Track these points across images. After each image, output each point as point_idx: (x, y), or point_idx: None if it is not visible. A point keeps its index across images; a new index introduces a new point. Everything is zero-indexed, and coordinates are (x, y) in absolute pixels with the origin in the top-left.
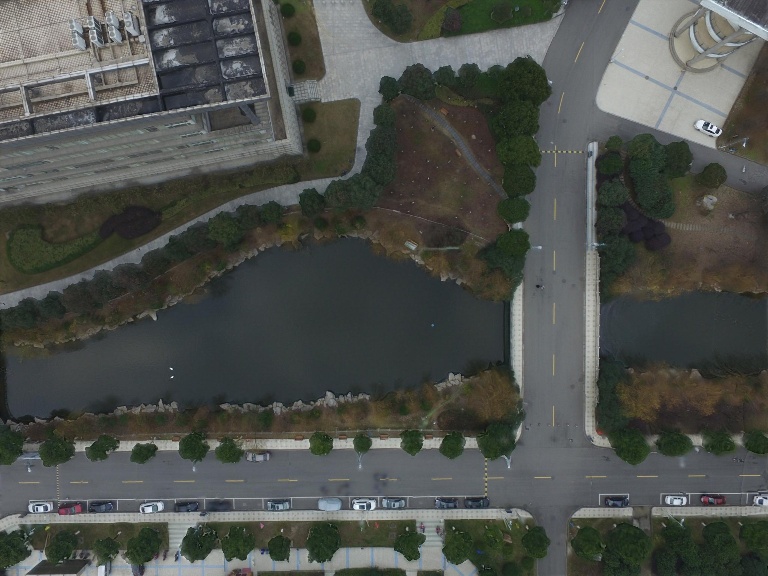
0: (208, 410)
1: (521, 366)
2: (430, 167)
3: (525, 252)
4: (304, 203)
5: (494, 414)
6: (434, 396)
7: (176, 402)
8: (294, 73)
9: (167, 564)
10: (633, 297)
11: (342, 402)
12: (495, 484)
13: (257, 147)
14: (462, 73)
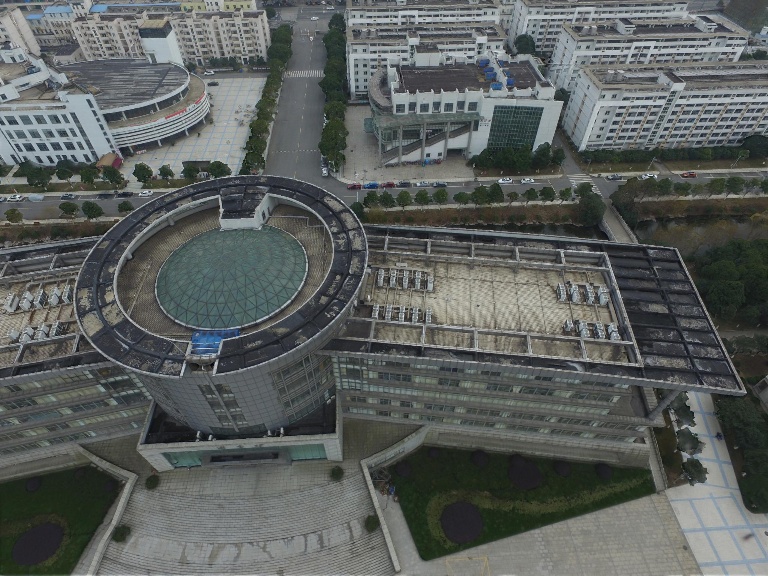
0: None
1: None
2: None
3: None
4: None
5: None
6: None
7: None
8: None
9: None
10: None
11: (2, 244)
12: None
13: None
14: None
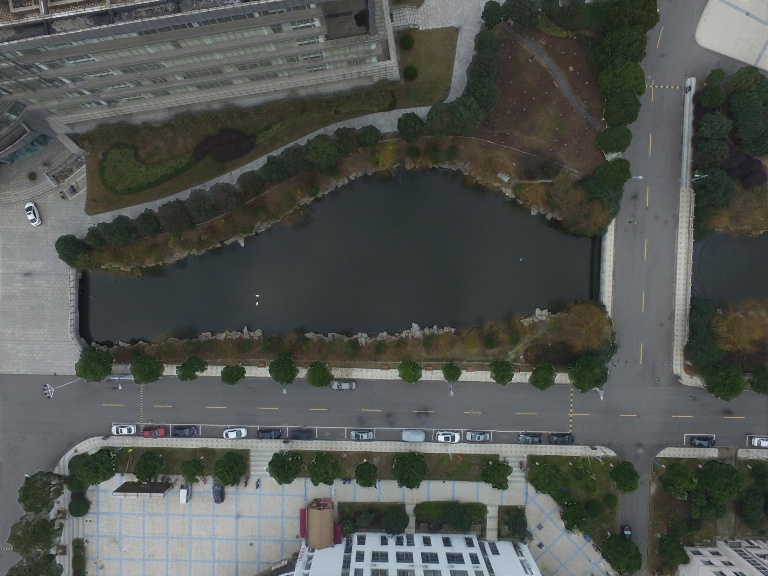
0: (296, 336)
1: (610, 302)
2: (526, 98)
3: (623, 183)
4: (406, 125)
5: (590, 344)
6: (522, 330)
7: (261, 330)
8: None
9: (247, 491)
10: (724, 237)
11: (427, 334)
12: (580, 421)
13: (360, 67)
14: (566, 0)
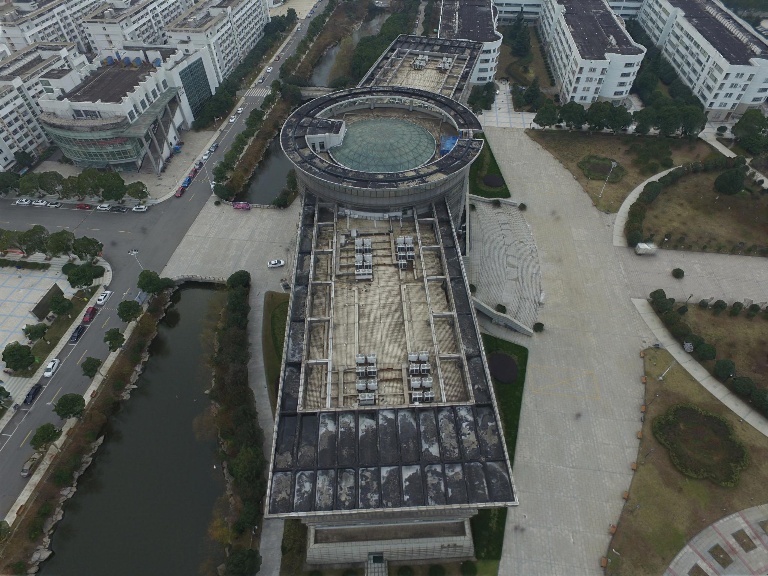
0: None
1: None
2: None
3: None
4: (240, 553)
5: None
6: None
7: None
8: (400, 567)
9: None
10: None
11: (30, 570)
12: None
13: None
14: None
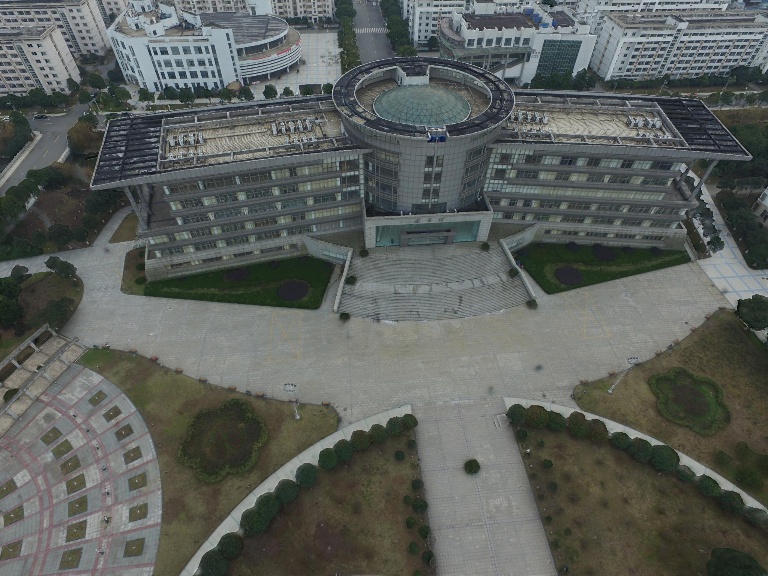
0: None
1: None
2: None
3: None
4: None
5: (82, 123)
6: None
7: None
8: None
9: None
10: None
11: None
12: None
13: None
14: None
